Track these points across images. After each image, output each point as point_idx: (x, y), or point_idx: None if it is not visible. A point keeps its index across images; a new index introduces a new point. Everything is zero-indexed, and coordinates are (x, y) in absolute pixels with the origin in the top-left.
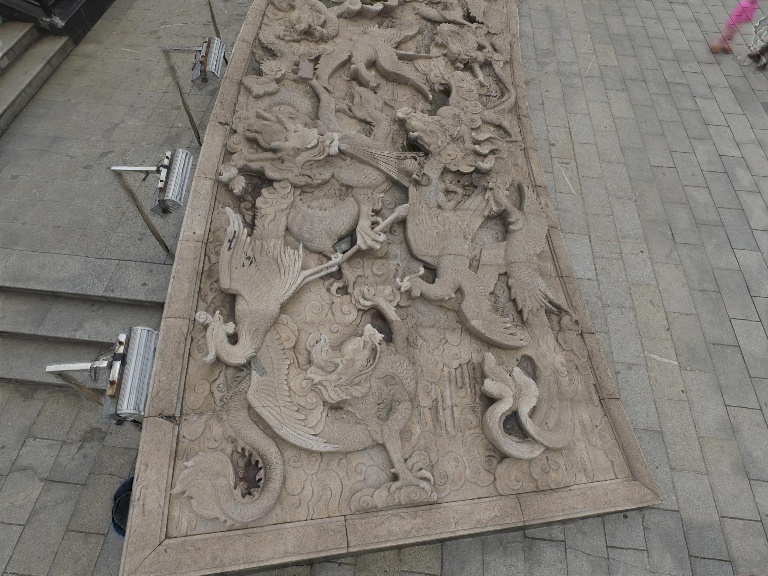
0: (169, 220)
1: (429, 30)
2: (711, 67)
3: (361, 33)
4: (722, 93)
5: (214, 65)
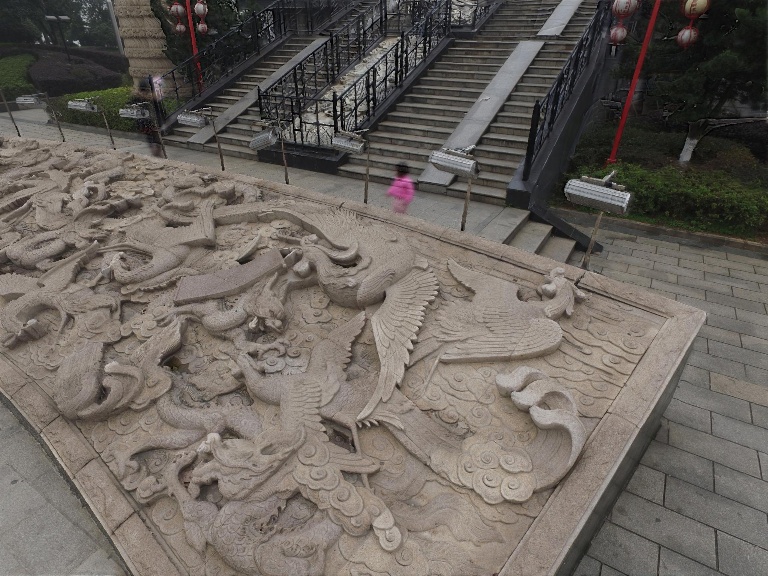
0: None
1: None
2: None
3: None
4: None
5: (21, 99)
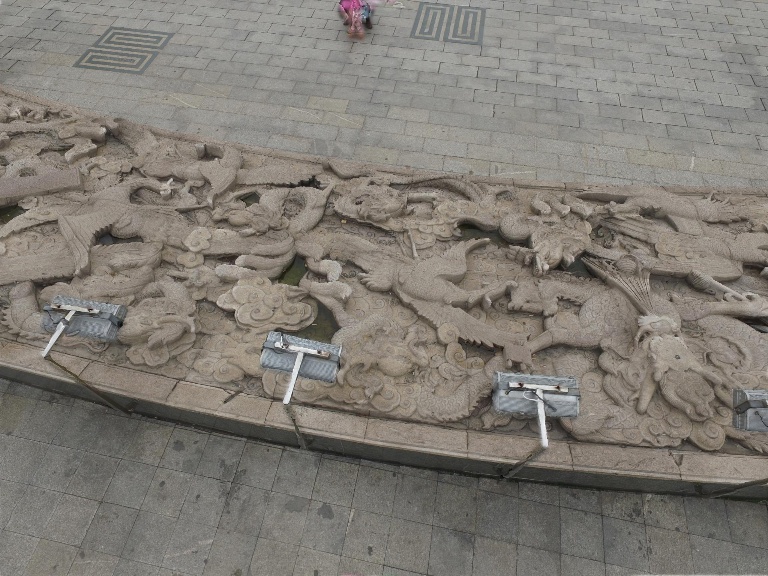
0: (753, 568)
1: (338, 227)
2: (358, 47)
3: (371, 296)
4: (396, 53)
5: None
